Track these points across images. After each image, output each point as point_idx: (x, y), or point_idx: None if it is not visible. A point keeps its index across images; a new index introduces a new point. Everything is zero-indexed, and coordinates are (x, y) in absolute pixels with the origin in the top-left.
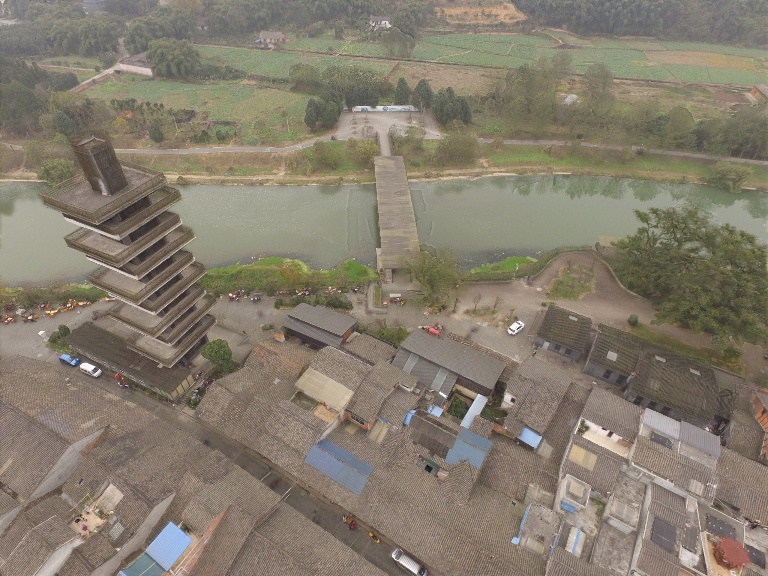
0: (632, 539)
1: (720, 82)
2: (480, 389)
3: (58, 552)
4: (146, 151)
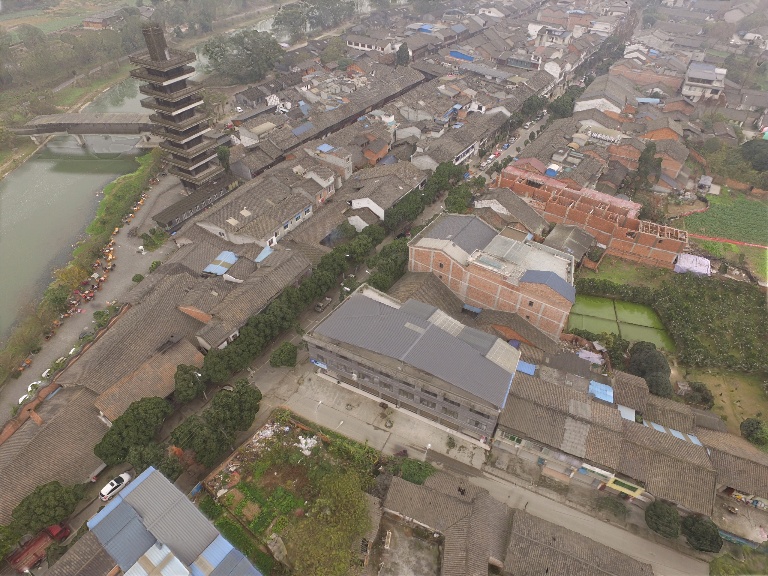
0: None
1: (56, 29)
2: (274, 111)
3: None
4: None
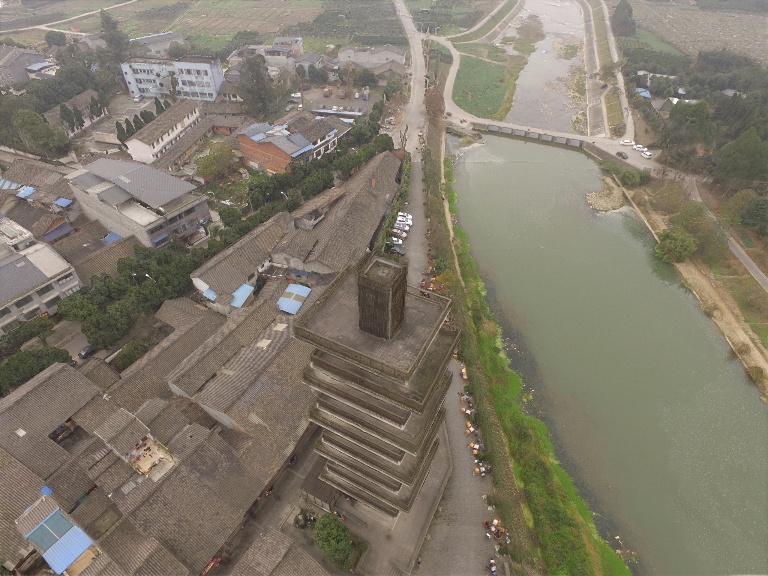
0: None
1: None
2: None
3: None
4: None
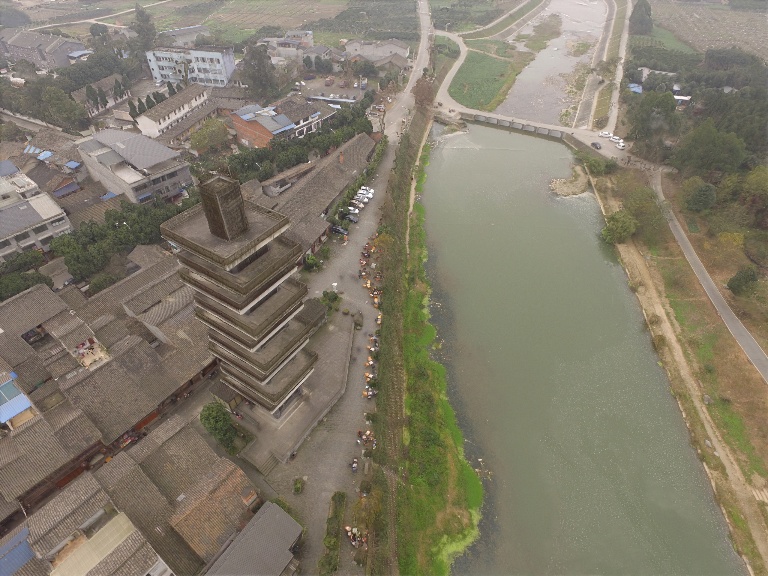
0: None
1: None
2: None
3: None
4: (710, 286)
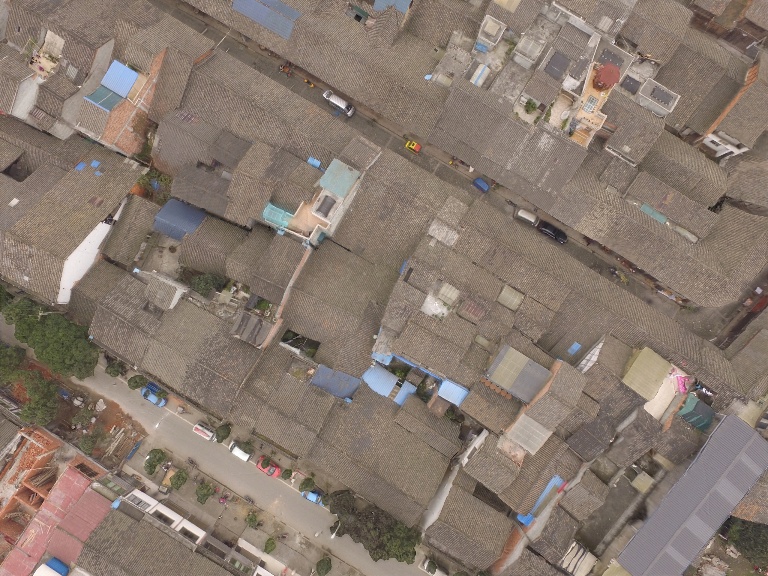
0: (530, 73)
1: None
2: None
3: (25, 85)
4: None
